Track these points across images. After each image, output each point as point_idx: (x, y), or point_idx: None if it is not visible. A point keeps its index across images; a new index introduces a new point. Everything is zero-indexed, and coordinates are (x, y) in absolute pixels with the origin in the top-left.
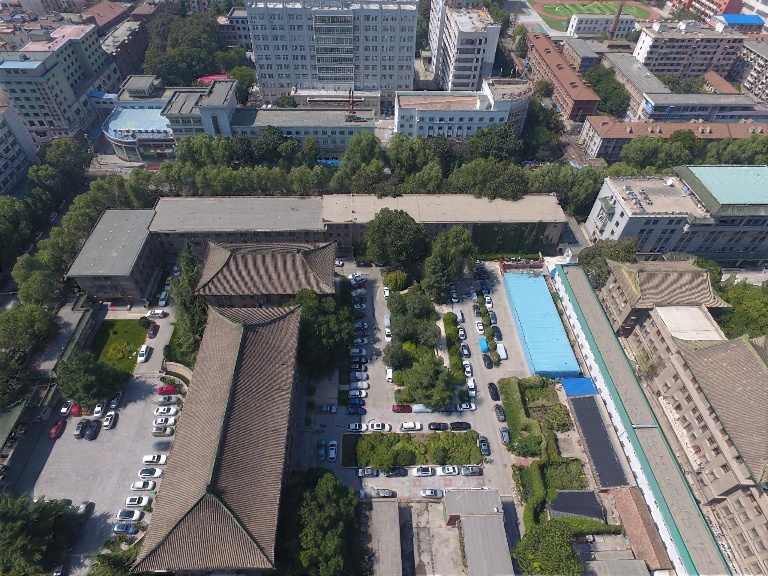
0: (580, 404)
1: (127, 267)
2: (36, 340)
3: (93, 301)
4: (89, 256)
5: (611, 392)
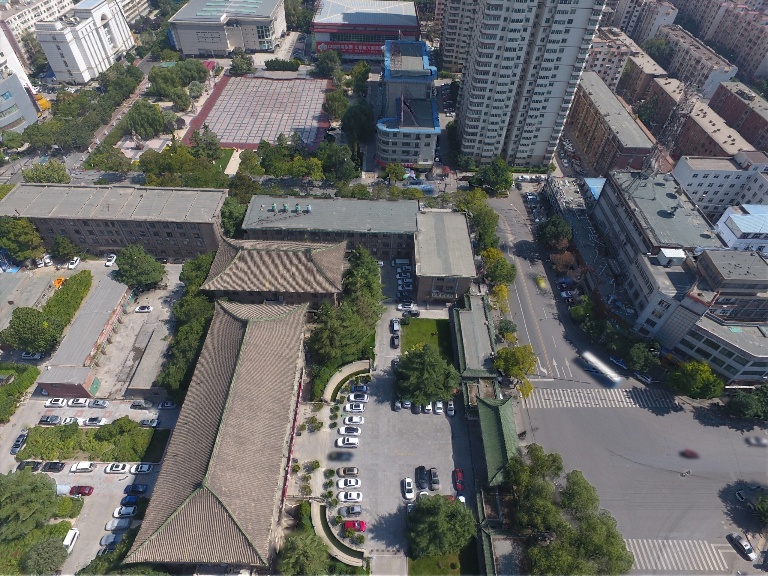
0: None
1: None
2: None
3: None
4: None
5: None
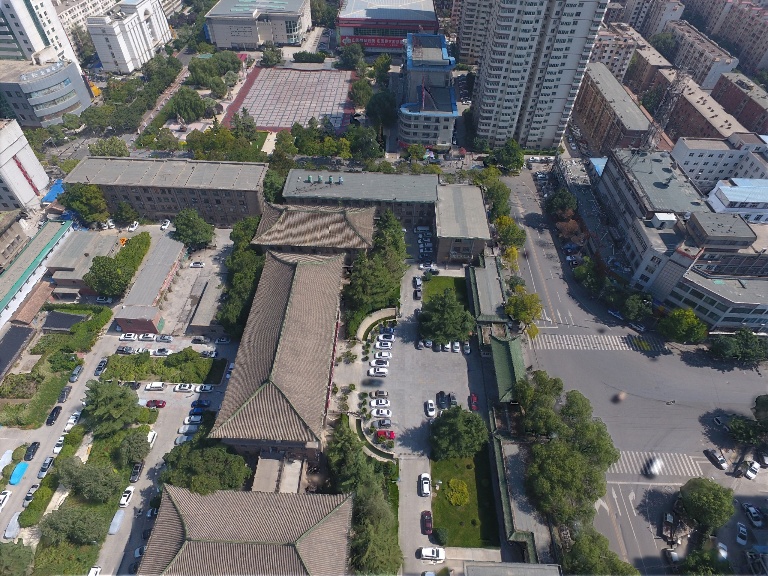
0: None
1: None
2: None
3: None
4: None
5: None
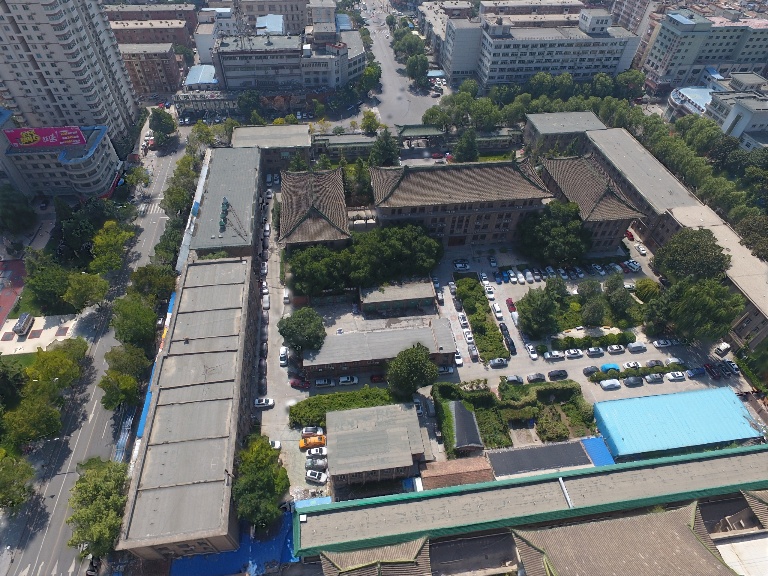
0: (576, 449)
1: (547, 132)
2: (481, 125)
3: (522, 141)
4: (546, 117)
5: (598, 467)
